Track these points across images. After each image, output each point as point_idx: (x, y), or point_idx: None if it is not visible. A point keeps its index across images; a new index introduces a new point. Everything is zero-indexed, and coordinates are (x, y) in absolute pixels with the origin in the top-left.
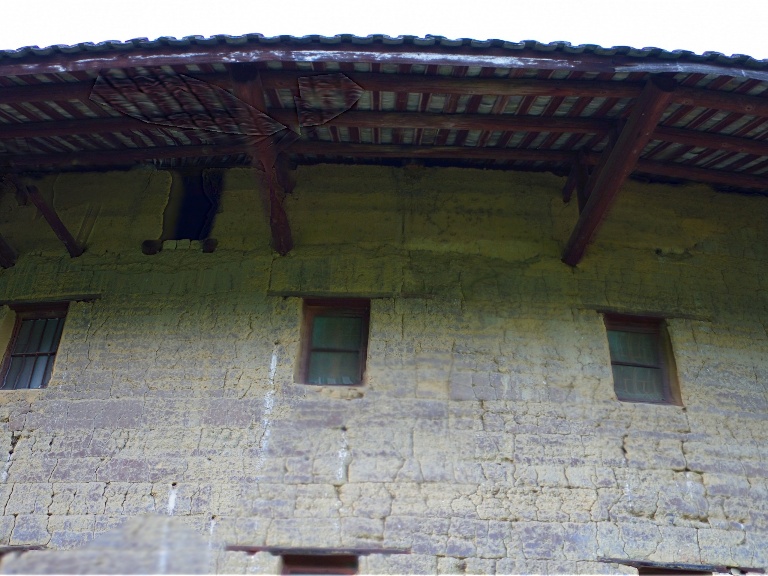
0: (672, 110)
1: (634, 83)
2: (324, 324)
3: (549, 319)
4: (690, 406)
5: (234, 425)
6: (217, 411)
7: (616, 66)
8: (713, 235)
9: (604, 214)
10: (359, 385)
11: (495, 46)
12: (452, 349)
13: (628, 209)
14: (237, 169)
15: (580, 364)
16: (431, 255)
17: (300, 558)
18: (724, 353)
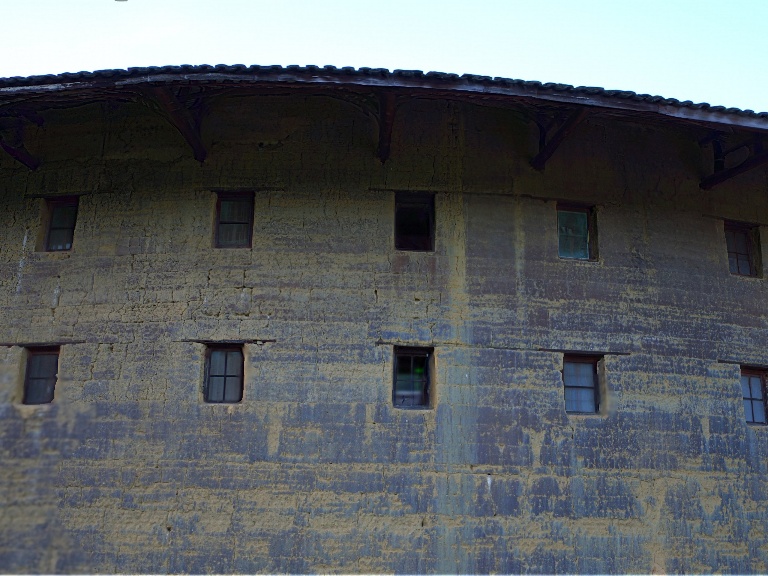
0: (177, 90)
1: (132, 88)
2: (60, 212)
3: (180, 200)
4: (255, 248)
5: (4, 278)
6: None
7: (115, 82)
8: (301, 128)
9: (229, 121)
10: (69, 250)
11: (48, 79)
12: (121, 224)
13: (245, 116)
14: (2, 118)
15: (193, 227)
16: (118, 162)
17: (34, 348)
18: (286, 211)
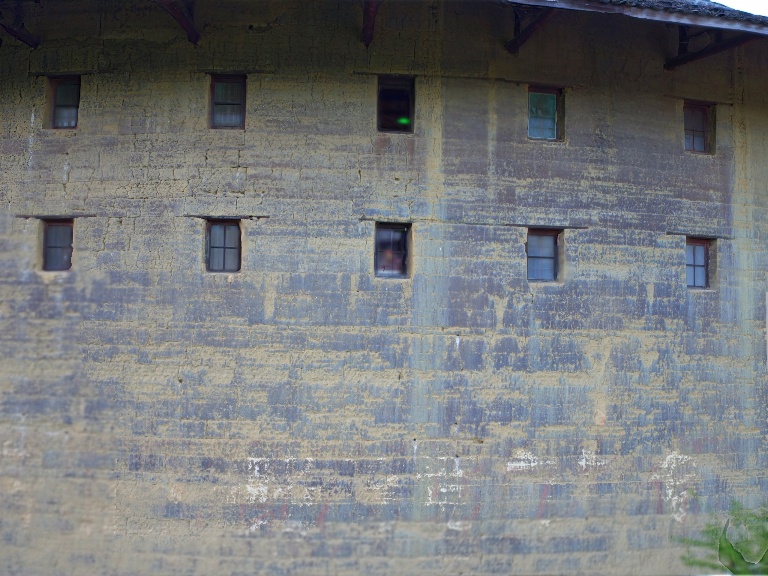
0: None
1: None
2: (63, 89)
3: (177, 81)
4: (248, 129)
5: (16, 154)
6: (7, 147)
7: None
8: (289, 10)
9: (220, 3)
10: (75, 128)
11: None
12: (122, 104)
13: None
14: None
15: (190, 109)
16: (116, 42)
17: (50, 220)
18: (276, 94)
